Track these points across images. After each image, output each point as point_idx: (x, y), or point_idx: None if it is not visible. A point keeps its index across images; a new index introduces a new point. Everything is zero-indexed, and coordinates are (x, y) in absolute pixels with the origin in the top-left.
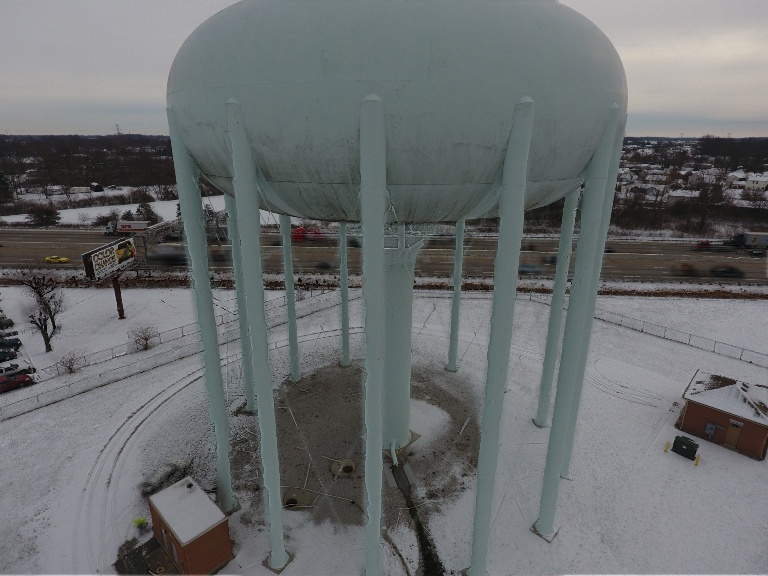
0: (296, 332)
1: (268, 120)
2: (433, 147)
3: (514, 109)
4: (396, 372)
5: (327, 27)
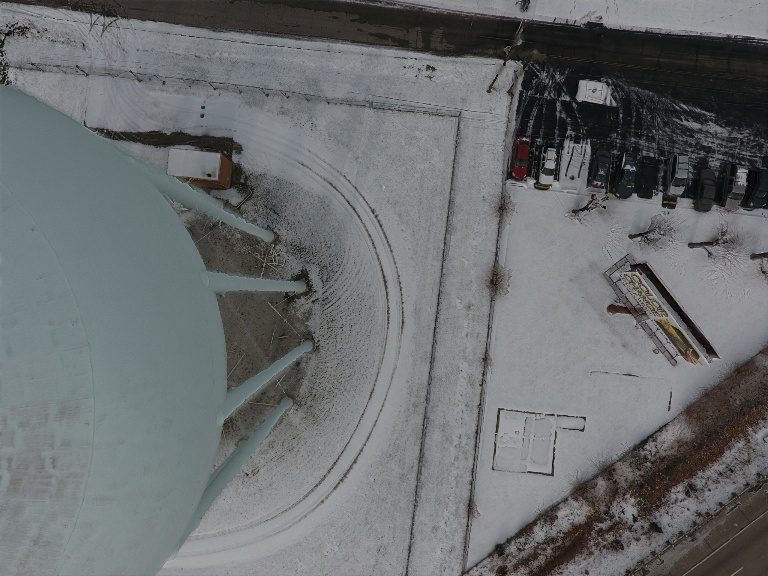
0: None
1: None
2: None
3: None
4: None
5: None
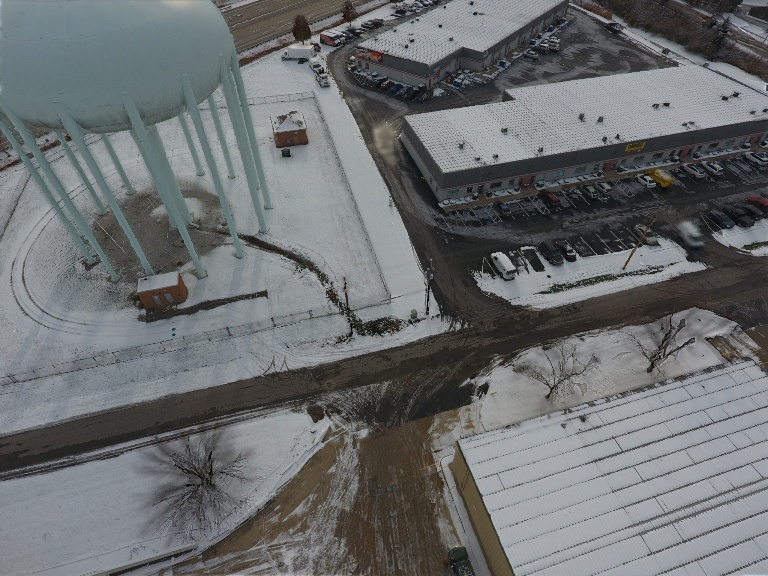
0: None
1: (146, 95)
2: (204, 83)
3: (219, 59)
4: (174, 186)
5: (154, 52)
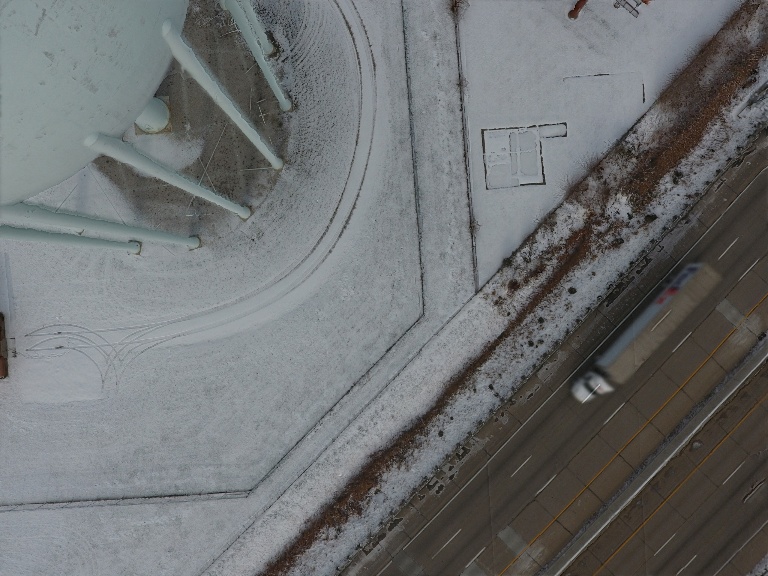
0: None
1: None
2: None
3: None
4: None
5: None
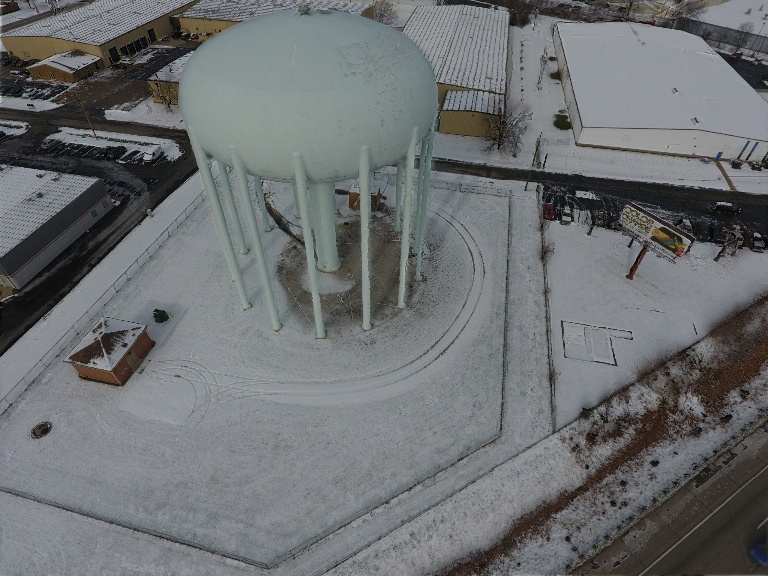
0: (418, 251)
1: None
2: None
3: None
4: None
5: None
